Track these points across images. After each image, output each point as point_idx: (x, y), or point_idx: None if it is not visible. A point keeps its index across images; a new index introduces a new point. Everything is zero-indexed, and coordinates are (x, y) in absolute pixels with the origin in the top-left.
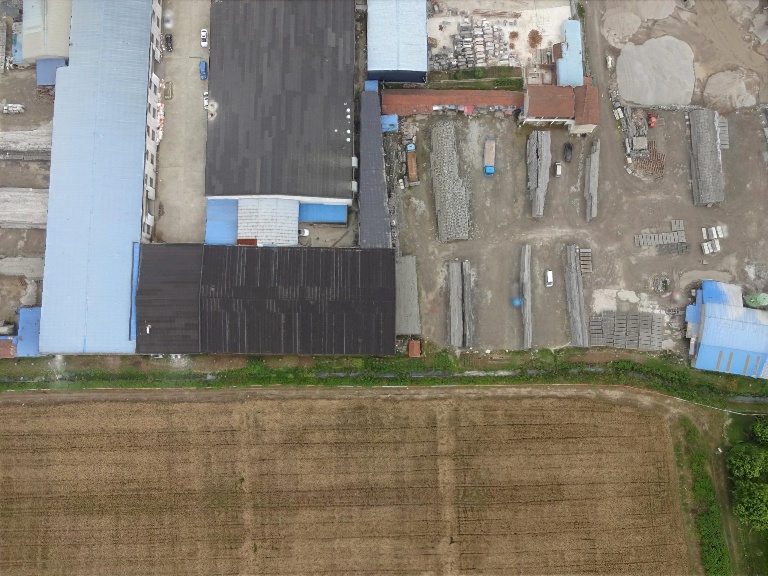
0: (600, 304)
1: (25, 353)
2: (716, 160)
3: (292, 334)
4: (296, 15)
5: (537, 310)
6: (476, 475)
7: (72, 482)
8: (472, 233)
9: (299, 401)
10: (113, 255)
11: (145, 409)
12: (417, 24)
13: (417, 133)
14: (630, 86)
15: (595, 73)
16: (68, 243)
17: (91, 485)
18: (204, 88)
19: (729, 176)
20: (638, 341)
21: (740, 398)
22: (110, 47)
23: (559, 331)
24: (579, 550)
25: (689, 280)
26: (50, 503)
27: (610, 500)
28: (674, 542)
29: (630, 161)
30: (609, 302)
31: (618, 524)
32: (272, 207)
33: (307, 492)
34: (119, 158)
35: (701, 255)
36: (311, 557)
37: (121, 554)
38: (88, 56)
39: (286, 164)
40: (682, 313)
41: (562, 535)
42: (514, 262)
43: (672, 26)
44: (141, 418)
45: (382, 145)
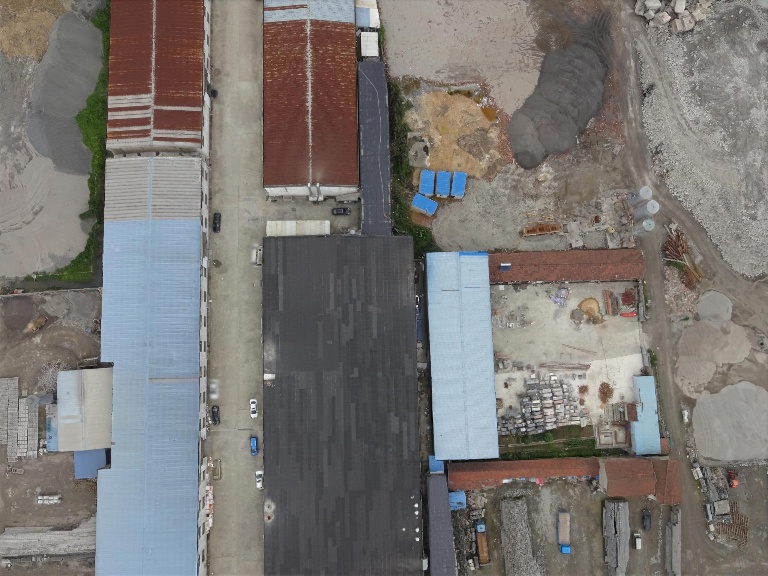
0: None
1: None
2: None
3: None
4: (357, 403)
5: None
6: None
7: None
8: None
9: None
10: None
11: None
12: (486, 404)
13: (485, 505)
14: (709, 444)
15: (671, 428)
16: None
17: None
18: (255, 464)
19: None
20: None
21: None
22: (156, 447)
23: None
24: None
25: None
26: None
27: None
28: None
29: (712, 529)
30: None
31: None
32: None
33: None
34: (170, 574)
35: None
36: None
37: None
38: (132, 458)
39: None
40: None
41: None
42: None
43: (748, 370)
44: None
45: (453, 539)
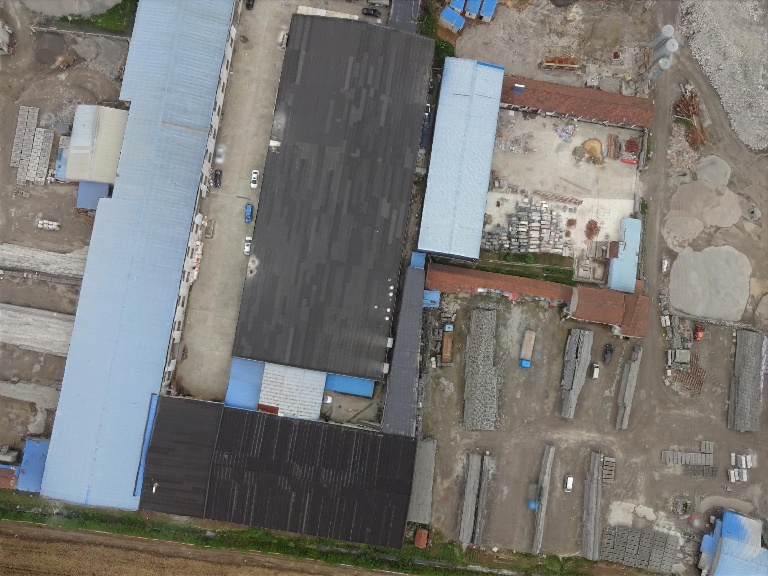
0: (616, 517)
1: (25, 487)
2: (757, 387)
3: (300, 514)
4: (353, 181)
5: (551, 514)
6: None
7: None
8: (497, 424)
9: (296, 573)
10: (130, 405)
11: (139, 559)
12: (476, 207)
13: (457, 311)
14: (682, 295)
15: (648, 275)
16: (85, 386)
17: None
18: (247, 231)
19: (767, 403)
20: (648, 561)
21: None
22: (157, 185)
23: (570, 538)
24: None
25: (710, 505)
26: None
27: None
28: None
29: (670, 374)
30: (625, 516)
31: None
32: (299, 377)
33: None
34: (150, 304)
35: (726, 481)
36: None
37: None
38: (133, 191)
39: (320, 337)
40: (698, 541)
41: None
42: (535, 460)
43: (734, 236)
44: (134, 568)
45: (421, 327)
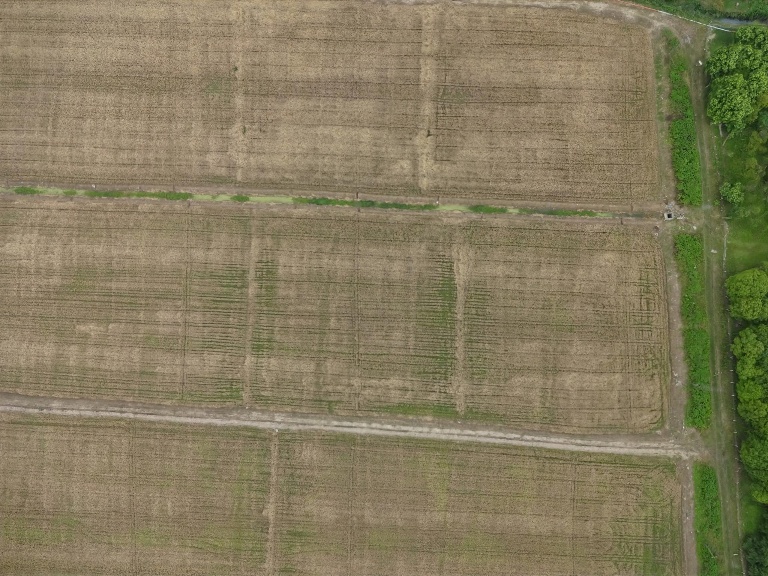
0: None
1: None
2: None
3: None
4: None
5: None
6: (456, 75)
7: (82, 63)
8: None
9: (292, 0)
10: None
11: (150, 1)
12: None
13: None
14: None
15: None
16: None
17: (98, 66)
18: None
19: None
20: None
21: (726, 21)
22: None
23: None
24: (551, 149)
25: None
26: (61, 80)
27: (586, 105)
28: (646, 147)
29: None
30: None
31: (592, 127)
32: None
33: (295, 82)
34: None
35: None
36: (295, 140)
37: (123, 128)
38: None
39: None
40: None
41: (536, 134)
42: None
43: None
44: (146, 9)
45: None
